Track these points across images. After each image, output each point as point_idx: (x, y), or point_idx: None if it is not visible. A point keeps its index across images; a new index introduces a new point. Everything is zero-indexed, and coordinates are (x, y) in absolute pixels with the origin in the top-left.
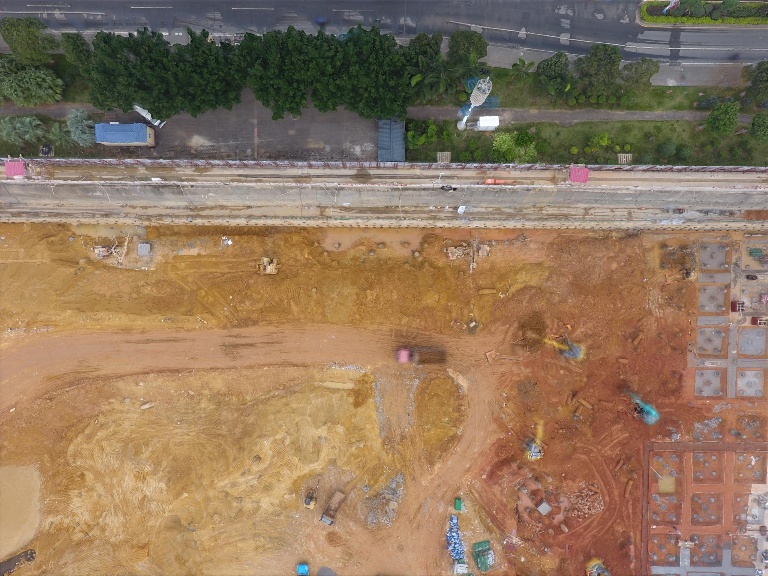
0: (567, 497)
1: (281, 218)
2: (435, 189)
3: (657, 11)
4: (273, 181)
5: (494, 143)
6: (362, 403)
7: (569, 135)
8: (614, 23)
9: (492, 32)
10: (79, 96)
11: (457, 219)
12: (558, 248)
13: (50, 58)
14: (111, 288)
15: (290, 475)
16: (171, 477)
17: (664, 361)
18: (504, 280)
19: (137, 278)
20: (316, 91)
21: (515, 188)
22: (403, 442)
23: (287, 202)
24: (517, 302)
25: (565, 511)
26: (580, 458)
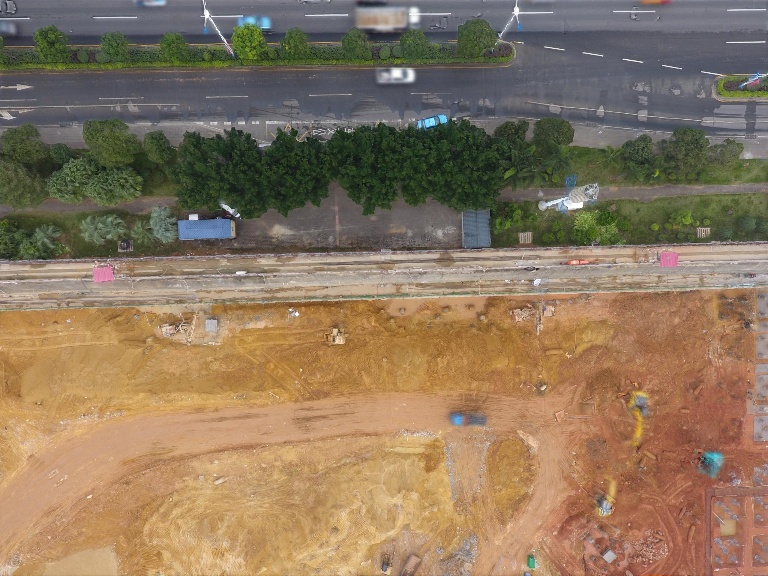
0: (631, 544)
1: (358, 297)
2: (518, 270)
3: (734, 86)
4: (356, 268)
5: (575, 222)
6: (434, 468)
7: (649, 211)
8: (691, 98)
9: (570, 111)
10: (156, 189)
11: (533, 292)
12: (621, 305)
13: (132, 158)
14: (180, 366)
15: (367, 543)
16: (248, 551)
17: (724, 409)
18: (570, 340)
19: (205, 354)
20: (407, 186)
21: (597, 266)
22: (475, 503)
23: (364, 282)
24: (585, 363)
25: (629, 557)
26: (646, 508)
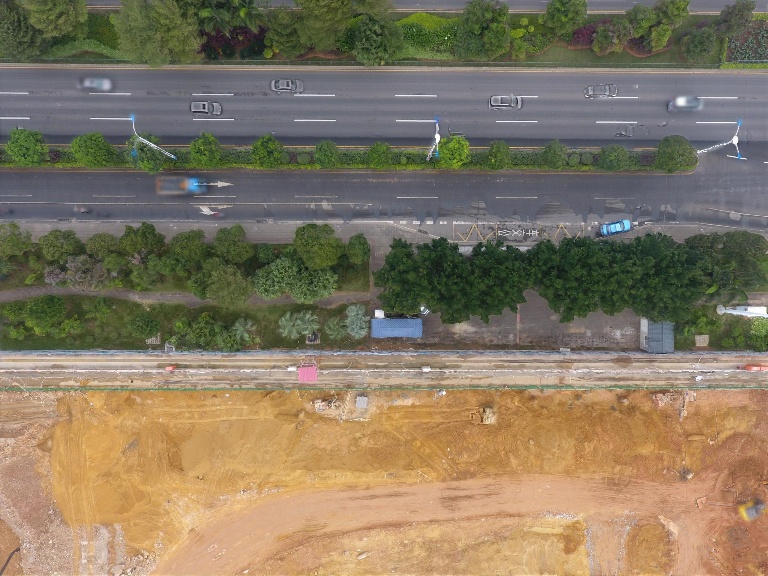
0: None
1: (522, 387)
2: (693, 372)
3: None
4: (536, 366)
5: (753, 327)
6: (574, 550)
7: None
8: None
9: (751, 218)
10: (346, 285)
11: None
12: (762, 392)
13: (337, 261)
14: (330, 441)
15: None
16: None
17: None
18: (712, 426)
19: (354, 430)
20: (606, 297)
21: None
22: None
23: None
24: (729, 451)
25: None
26: None
